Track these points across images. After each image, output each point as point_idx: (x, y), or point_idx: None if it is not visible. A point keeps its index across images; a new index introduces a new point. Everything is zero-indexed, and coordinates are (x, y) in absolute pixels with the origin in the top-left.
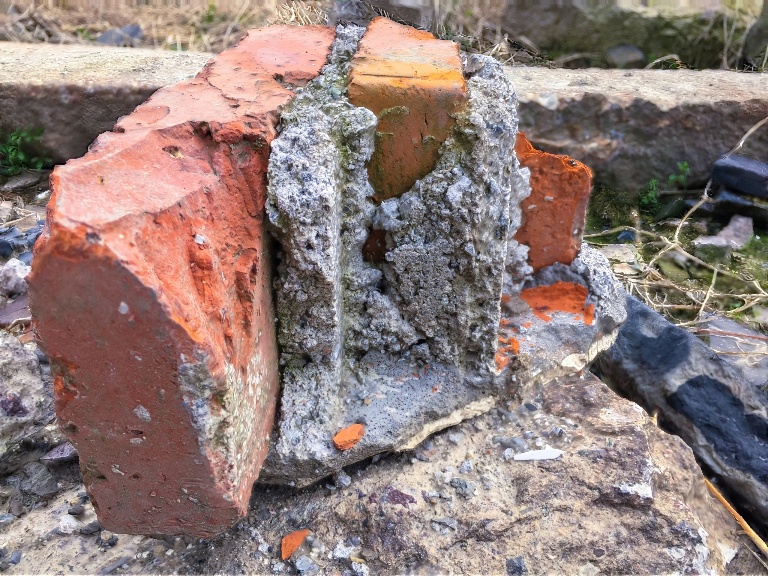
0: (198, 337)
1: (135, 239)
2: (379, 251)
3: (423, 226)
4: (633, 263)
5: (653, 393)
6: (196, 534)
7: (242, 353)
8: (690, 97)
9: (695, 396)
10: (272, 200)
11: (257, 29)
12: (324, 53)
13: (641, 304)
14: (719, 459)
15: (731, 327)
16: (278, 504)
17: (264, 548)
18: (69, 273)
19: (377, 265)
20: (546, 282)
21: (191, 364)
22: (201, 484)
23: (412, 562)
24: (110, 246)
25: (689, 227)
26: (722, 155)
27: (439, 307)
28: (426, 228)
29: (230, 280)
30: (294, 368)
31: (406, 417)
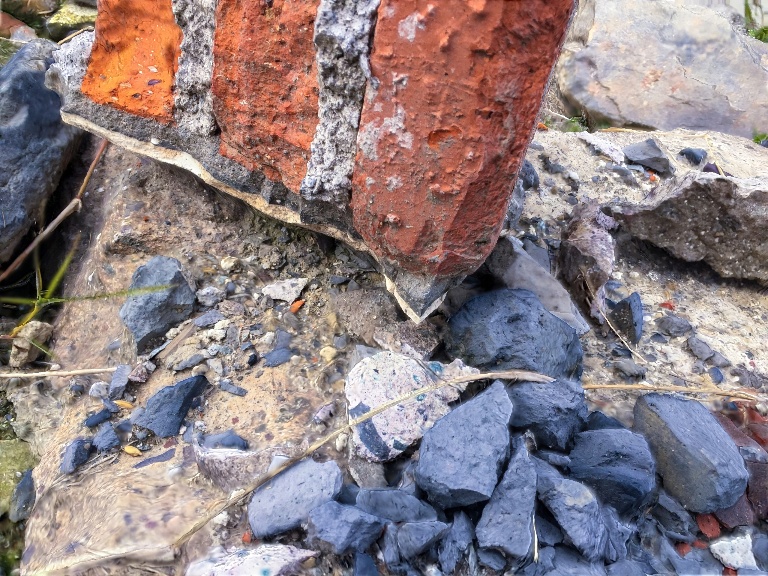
0: None
1: None
2: None
3: None
4: None
5: None
6: None
7: None
8: None
9: None
10: None
11: None
12: None
13: None
14: None
15: None
16: None
17: None
18: None
19: None
20: None
21: None
22: None
23: None
24: None
25: None
26: None
27: None
28: None
29: None
30: None
31: None
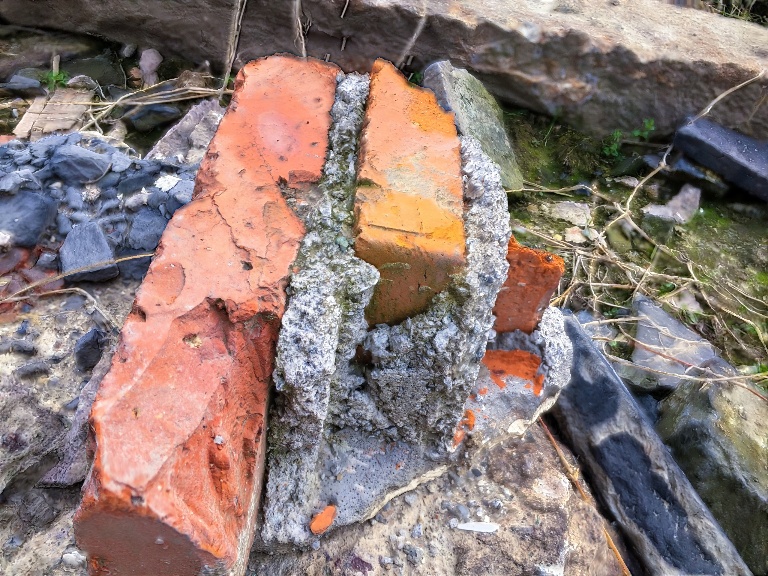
0: (221, 554)
1: (170, 484)
2: (364, 356)
3: (408, 355)
4: (584, 228)
5: (579, 437)
6: None
7: (245, 502)
8: (672, 49)
9: (613, 450)
10: (280, 371)
11: (254, 66)
12: (325, 125)
13: (584, 340)
14: (622, 508)
15: (658, 315)
16: (257, 561)
17: None
18: (114, 523)
19: (361, 367)
20: (506, 347)
21: (213, 569)
22: None
23: None
24: (152, 507)
25: (642, 190)
26: (688, 118)
27: (412, 410)
28: (411, 357)
29: (239, 450)
30: (278, 454)
31: (372, 497)
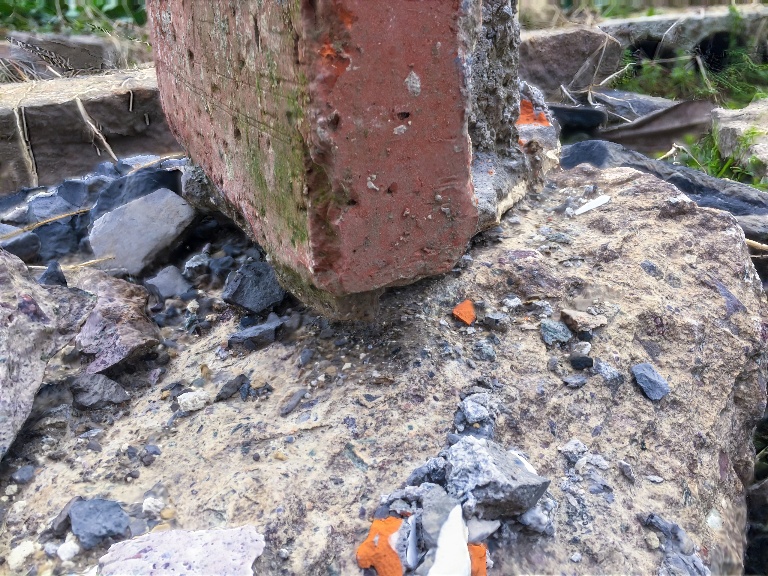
0: None
1: None
2: None
3: None
4: None
5: None
6: (437, 268)
7: None
8: None
9: None
10: None
11: None
12: None
13: None
14: None
15: None
16: (419, 297)
17: (445, 322)
18: None
19: None
20: None
21: None
22: (455, 183)
23: (573, 291)
24: None
25: None
26: None
27: (481, 85)
28: None
29: None
30: None
31: (491, 190)
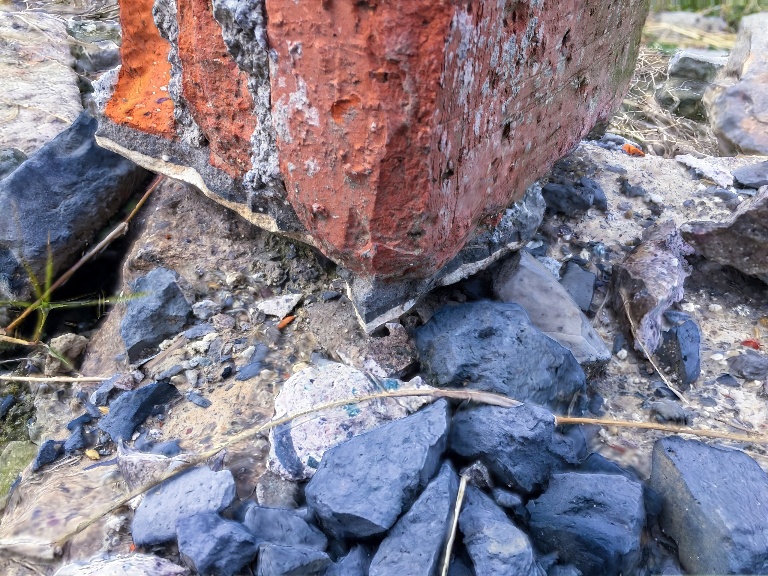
0: None
1: None
2: None
3: None
4: None
5: None
6: None
7: None
8: None
9: None
10: None
11: None
12: None
13: (32, 160)
14: None
15: None
16: None
17: None
18: None
19: None
20: None
21: None
22: None
23: None
24: None
25: None
26: None
27: None
28: None
29: None
30: None
31: None
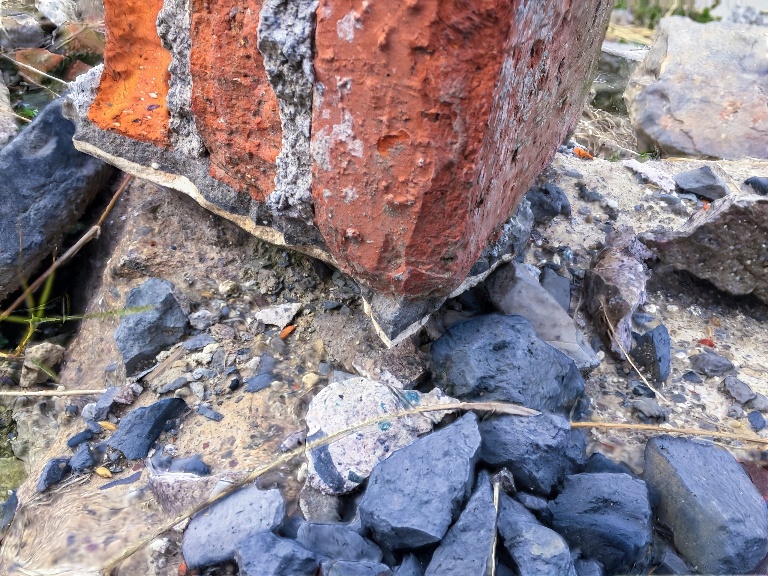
0: None
1: None
2: None
3: None
4: None
5: None
6: None
7: None
8: None
9: None
10: None
11: None
12: None
13: None
14: None
15: None
16: None
17: None
18: None
19: None
20: None
21: None
22: None
23: None
24: None
25: None
26: None
27: None
28: None
29: None
30: None
31: None
